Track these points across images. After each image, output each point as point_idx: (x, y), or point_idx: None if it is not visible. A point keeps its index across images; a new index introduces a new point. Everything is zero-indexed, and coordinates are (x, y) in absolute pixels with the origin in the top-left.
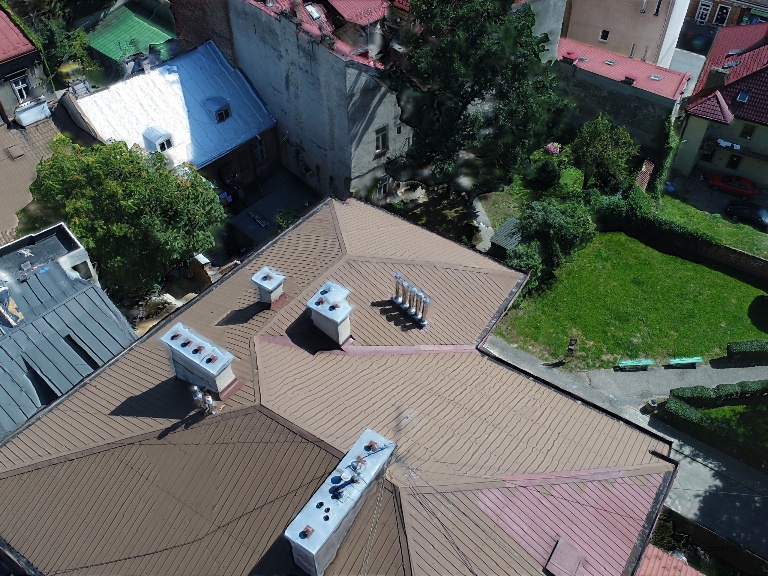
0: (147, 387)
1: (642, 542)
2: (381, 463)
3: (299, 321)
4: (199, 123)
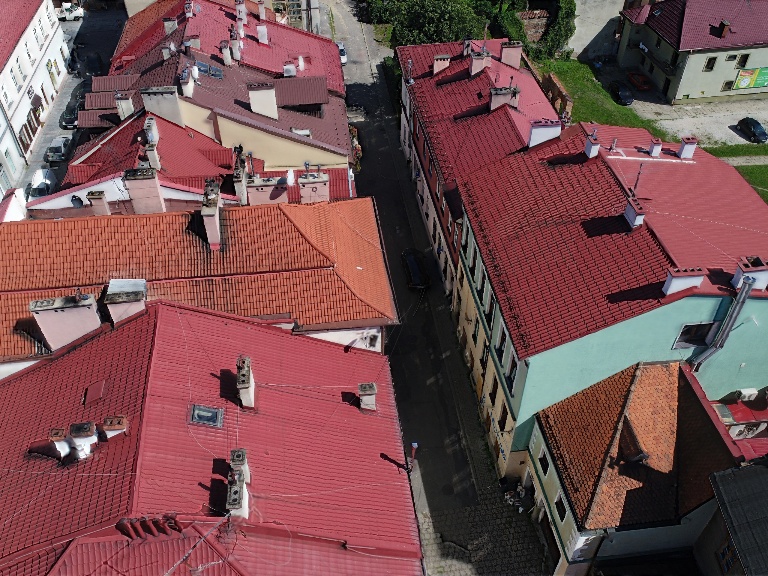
0: None
1: None
2: None
3: None
4: None
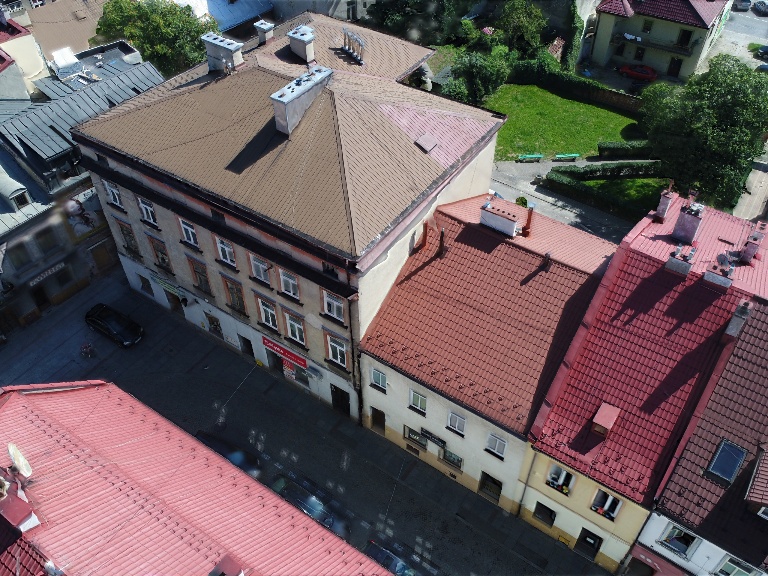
0: None
1: (477, 146)
2: (323, 76)
3: (283, 50)
4: (215, 3)
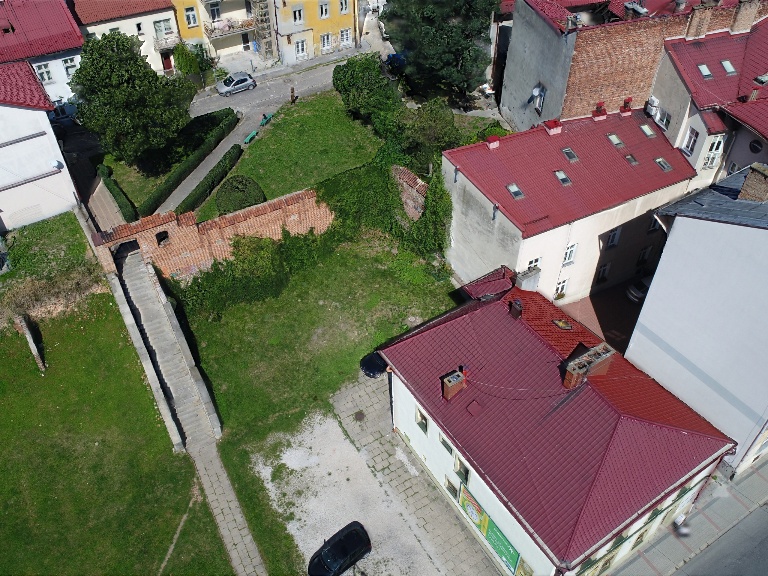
0: None
1: None
2: None
3: None
4: None
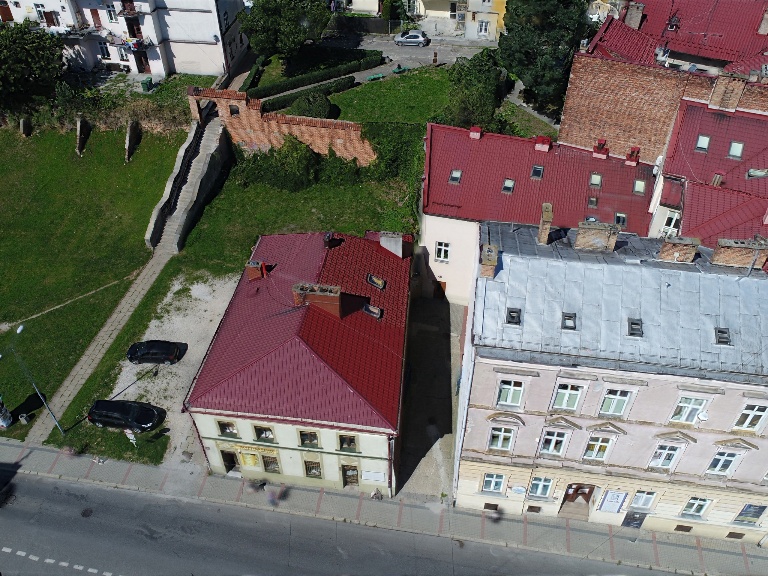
0: None
1: None
2: None
3: None
4: None
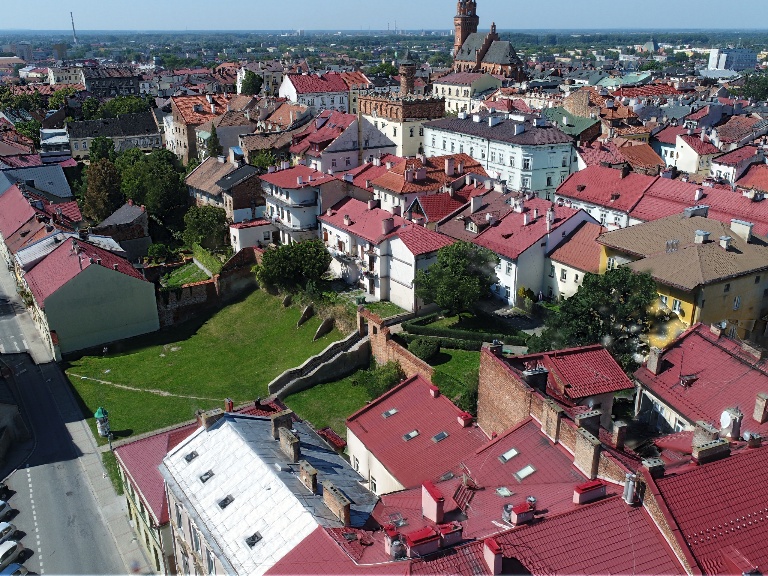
0: (761, 246)
1: None
2: None
3: None
4: None
